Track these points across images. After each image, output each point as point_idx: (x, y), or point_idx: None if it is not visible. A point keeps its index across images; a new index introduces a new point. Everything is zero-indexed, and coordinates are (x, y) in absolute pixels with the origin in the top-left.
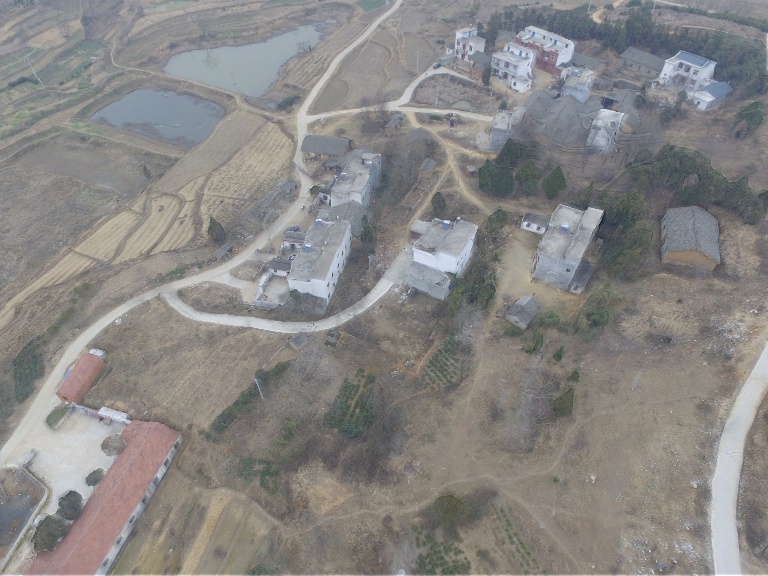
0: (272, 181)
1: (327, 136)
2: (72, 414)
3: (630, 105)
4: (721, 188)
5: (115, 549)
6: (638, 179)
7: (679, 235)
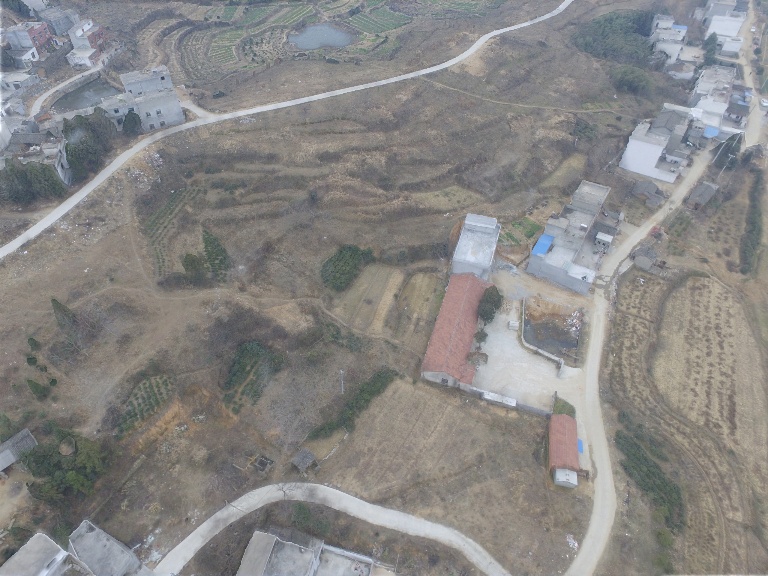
0: None
1: None
2: None
3: None
4: None
5: None
6: None
7: None
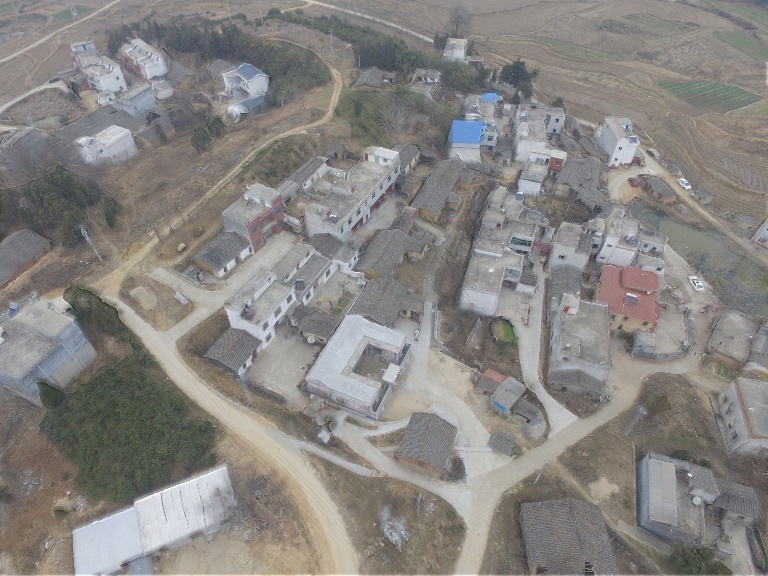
0: None
1: None
2: None
3: (166, 120)
4: (49, 210)
5: None
6: None
7: None
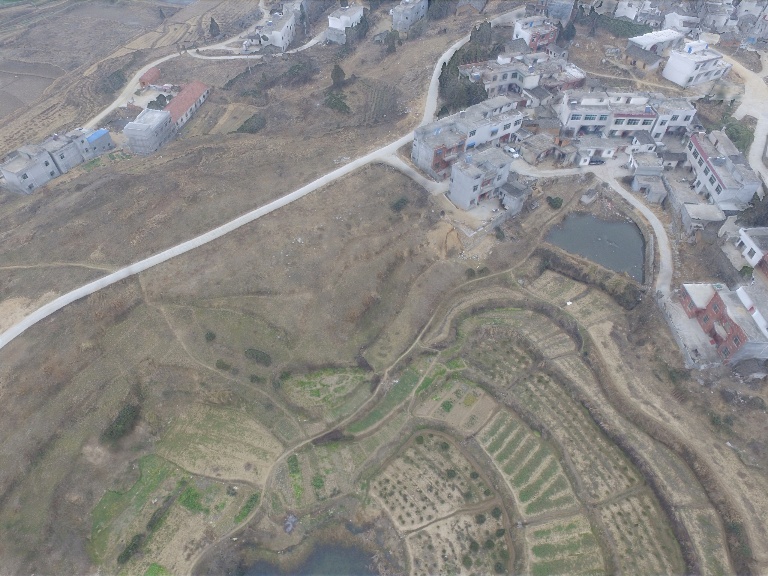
0: (245, 15)
1: None
2: (148, 91)
3: None
4: None
5: (185, 118)
6: None
7: (463, 1)
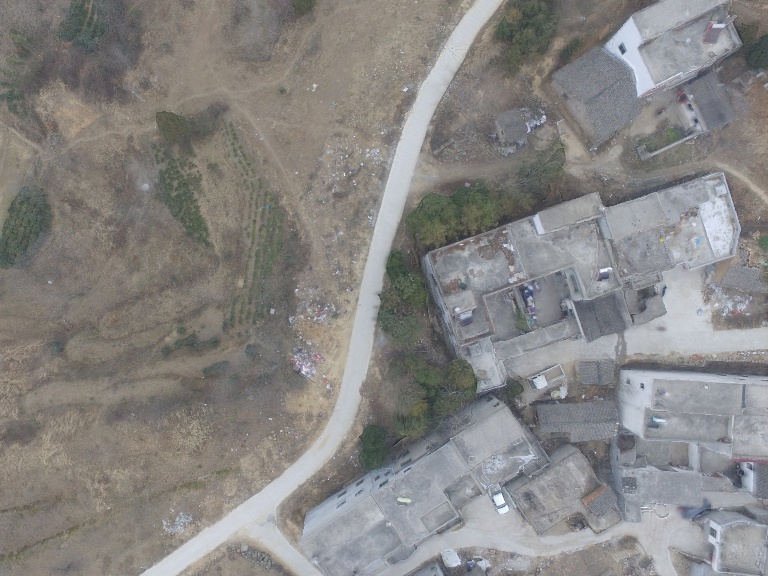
0: None
1: None
2: None
3: None
4: None
5: None
6: None
7: None
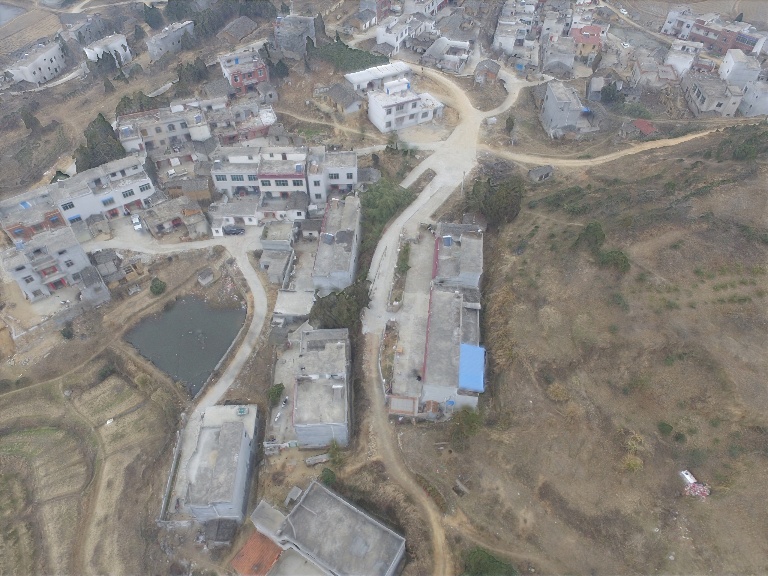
0: None
1: (78, 13)
2: None
3: None
4: (256, 5)
5: None
6: (220, 6)
7: None
